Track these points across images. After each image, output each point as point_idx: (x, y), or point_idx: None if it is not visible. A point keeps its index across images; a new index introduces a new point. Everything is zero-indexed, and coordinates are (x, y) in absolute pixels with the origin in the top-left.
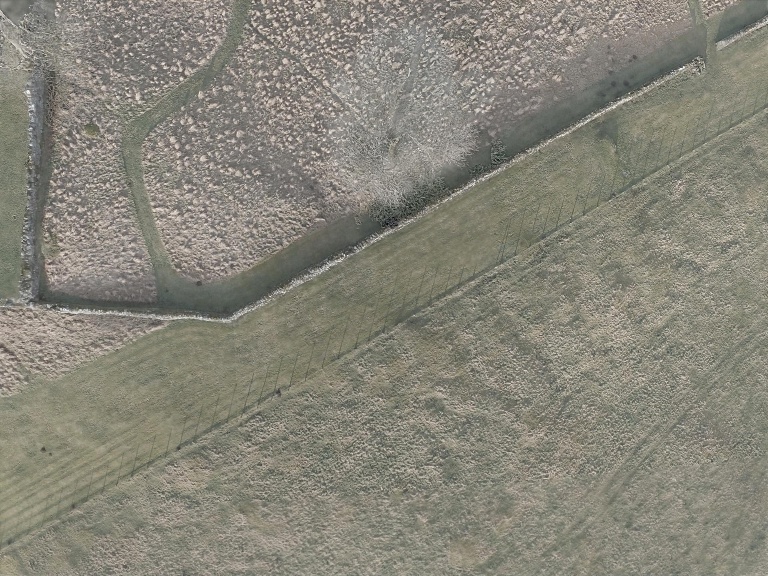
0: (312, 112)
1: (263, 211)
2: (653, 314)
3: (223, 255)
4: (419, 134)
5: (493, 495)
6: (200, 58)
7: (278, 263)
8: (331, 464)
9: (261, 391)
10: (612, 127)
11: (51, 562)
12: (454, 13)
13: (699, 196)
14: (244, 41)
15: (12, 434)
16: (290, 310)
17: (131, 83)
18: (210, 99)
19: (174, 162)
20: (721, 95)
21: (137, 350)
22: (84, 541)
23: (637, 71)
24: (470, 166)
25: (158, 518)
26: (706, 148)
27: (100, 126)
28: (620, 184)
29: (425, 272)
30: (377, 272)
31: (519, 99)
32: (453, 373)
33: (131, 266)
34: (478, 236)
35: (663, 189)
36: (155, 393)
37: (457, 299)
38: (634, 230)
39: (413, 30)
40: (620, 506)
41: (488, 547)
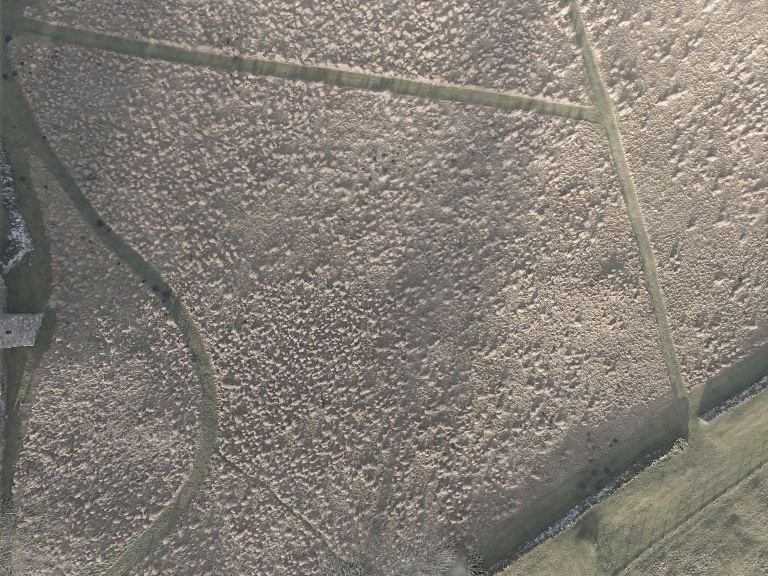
0: (282, 542)
1: None
2: None
3: None
4: (393, 555)
5: None
6: (165, 498)
7: None
8: None
9: None
10: (592, 522)
11: None
12: (429, 420)
13: (683, 575)
14: (212, 472)
15: None
16: None
17: (92, 544)
18: (175, 542)
19: None
20: (704, 467)
21: None
22: None
23: (618, 456)
24: None
25: None
26: (689, 524)
27: None
28: None
29: None
30: None
31: (497, 502)
32: None
33: None
34: None
35: (646, 573)
36: None
37: None
38: None
39: (387, 442)
40: None
41: None
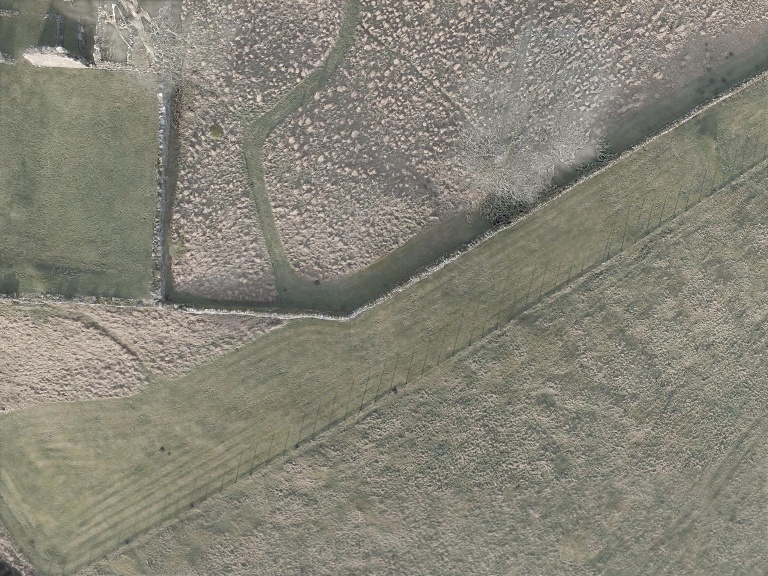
0: (423, 112)
1: (380, 210)
2: (753, 308)
3: (340, 254)
4: (527, 132)
5: (603, 490)
6: (315, 59)
7: (394, 261)
8: (446, 460)
9: (377, 389)
10: (712, 123)
11: (169, 561)
12: (558, 12)
13: None
14: (356, 42)
15: (131, 434)
16: (406, 308)
17: (252, 85)
18: (326, 100)
19: (293, 162)
20: None
21: (256, 349)
22: (203, 540)
23: (734, 68)
24: (577, 163)
25: (276, 516)
26: None
27: (224, 127)
28: (720, 180)
29: (535, 269)
30: (489, 269)
31: (621, 97)
32: (563, 369)
33: (252, 266)
34: (585, 233)
35: (760, 184)
36: (274, 392)
37: (566, 295)
38: (734, 225)
39: (519, 30)
40: (724, 500)
41: (598, 542)
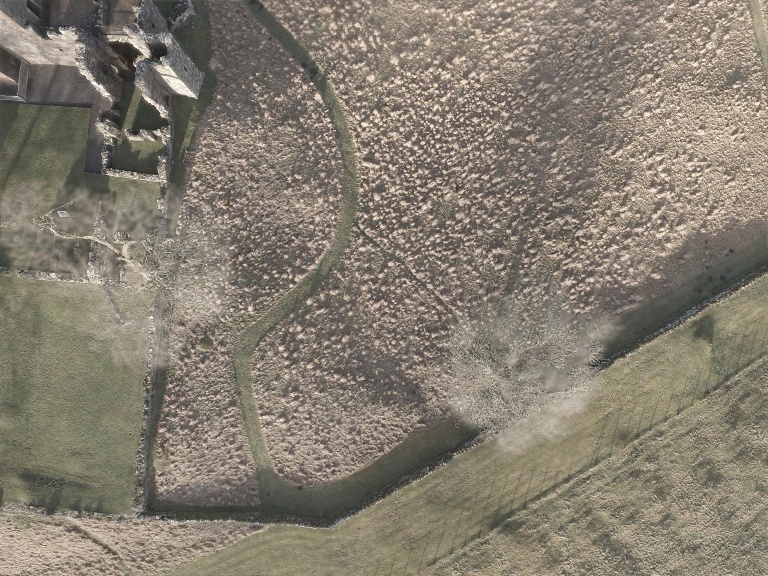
0: (415, 315)
1: (367, 418)
2: (742, 510)
3: (325, 461)
4: (519, 336)
5: None
6: (309, 263)
7: (379, 468)
8: None
9: None
10: (708, 325)
11: None
12: (556, 213)
13: None
14: (351, 243)
15: None
16: (389, 515)
17: (244, 294)
18: (318, 304)
19: (282, 370)
20: None
21: (237, 552)
22: None
23: (733, 265)
24: (568, 367)
25: None
26: None
27: (214, 339)
28: (714, 381)
29: (521, 475)
30: (474, 476)
31: (617, 297)
32: (545, 575)
33: (236, 472)
34: (574, 438)
35: (755, 383)
36: None
37: (551, 501)
38: (727, 427)
39: (516, 230)
40: None
41: None
